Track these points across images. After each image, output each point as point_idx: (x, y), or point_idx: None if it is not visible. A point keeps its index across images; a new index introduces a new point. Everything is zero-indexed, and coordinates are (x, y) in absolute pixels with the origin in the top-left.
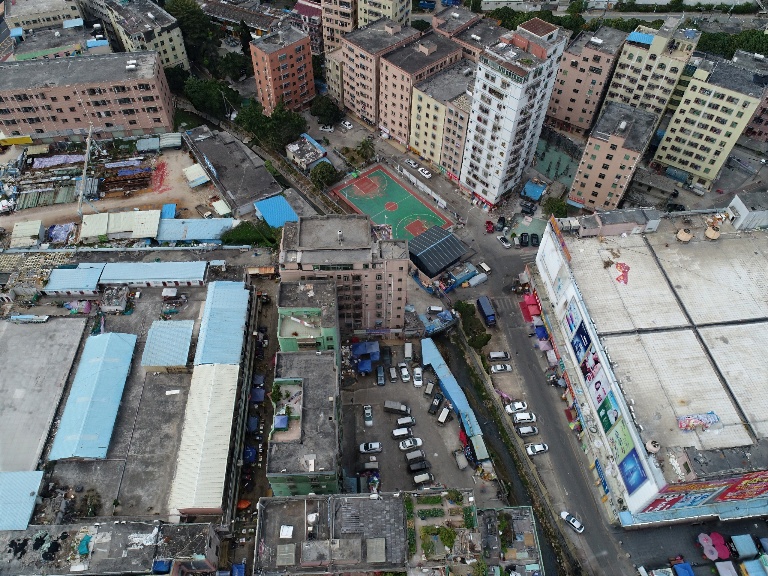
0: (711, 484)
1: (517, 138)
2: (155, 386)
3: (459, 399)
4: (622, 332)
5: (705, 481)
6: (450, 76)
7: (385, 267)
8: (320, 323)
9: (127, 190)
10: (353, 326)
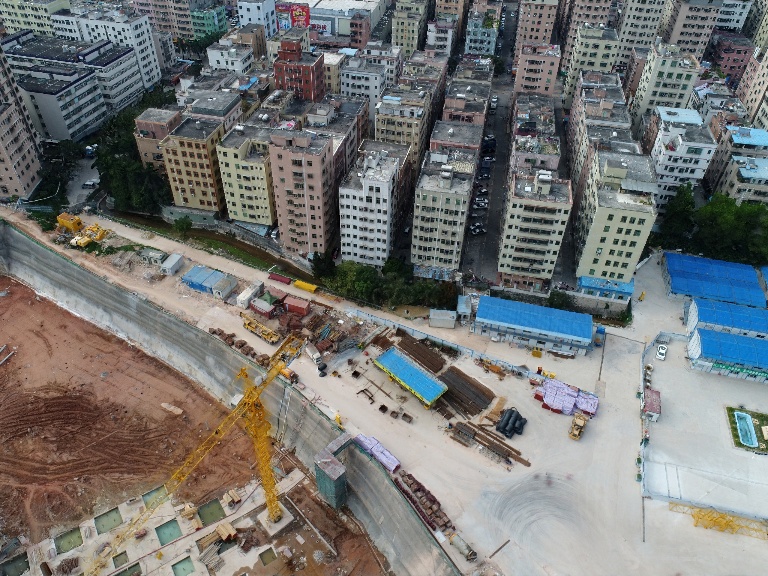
0: (280, 7)
1: None
2: None
3: None
4: None
5: (277, 4)
6: None
7: None
8: None
9: None
10: (220, 3)
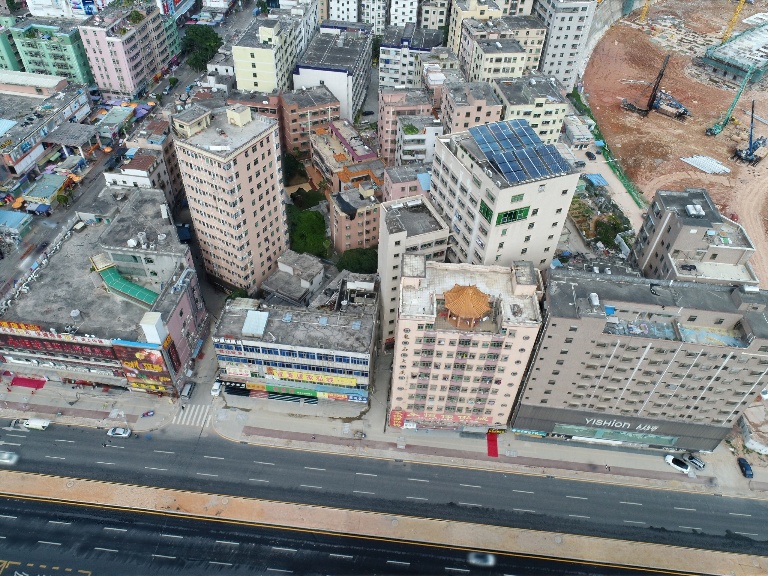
0: None
1: None
2: None
3: None
4: None
5: None
6: None
7: None
8: (7, 17)
9: None
10: None
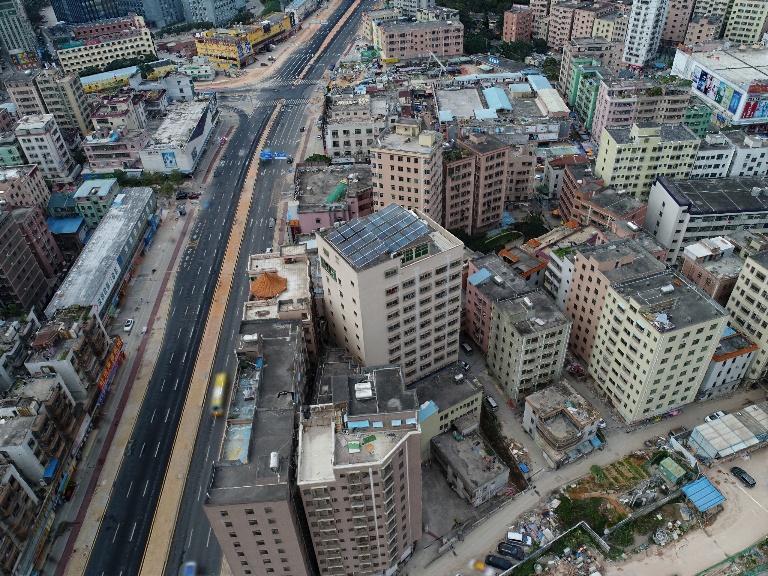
0: (767, 87)
1: (655, 25)
2: (519, 100)
3: None
4: (721, 69)
5: (765, 84)
6: (611, 16)
7: (615, 49)
8: (595, 61)
9: (452, 74)
10: None
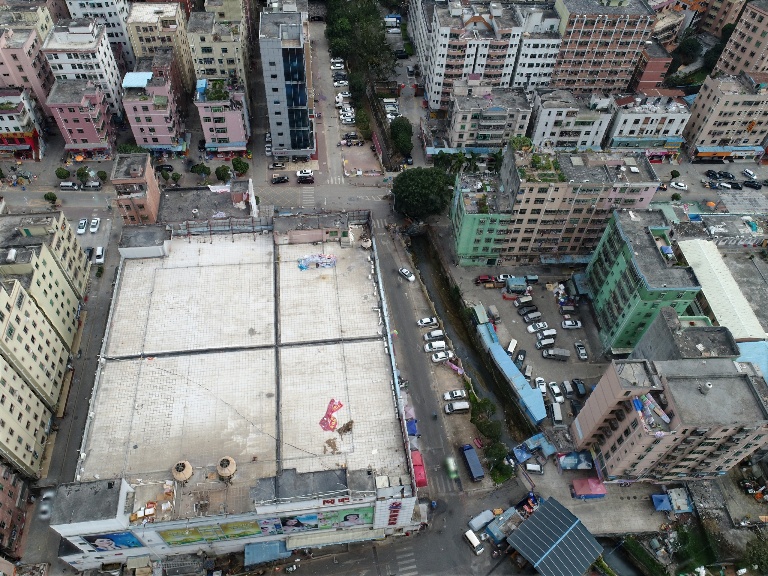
0: None
1: None
2: None
3: (501, 355)
4: (358, 340)
5: None
6: None
7: None
8: None
9: None
10: None
